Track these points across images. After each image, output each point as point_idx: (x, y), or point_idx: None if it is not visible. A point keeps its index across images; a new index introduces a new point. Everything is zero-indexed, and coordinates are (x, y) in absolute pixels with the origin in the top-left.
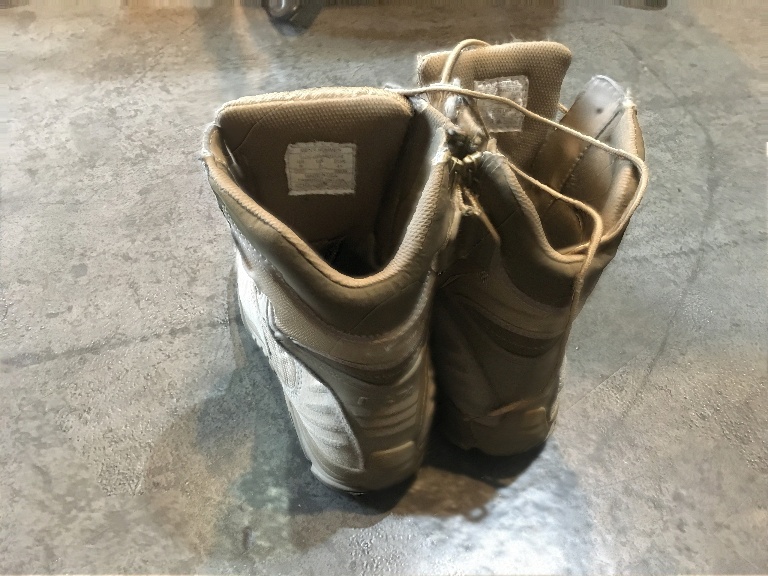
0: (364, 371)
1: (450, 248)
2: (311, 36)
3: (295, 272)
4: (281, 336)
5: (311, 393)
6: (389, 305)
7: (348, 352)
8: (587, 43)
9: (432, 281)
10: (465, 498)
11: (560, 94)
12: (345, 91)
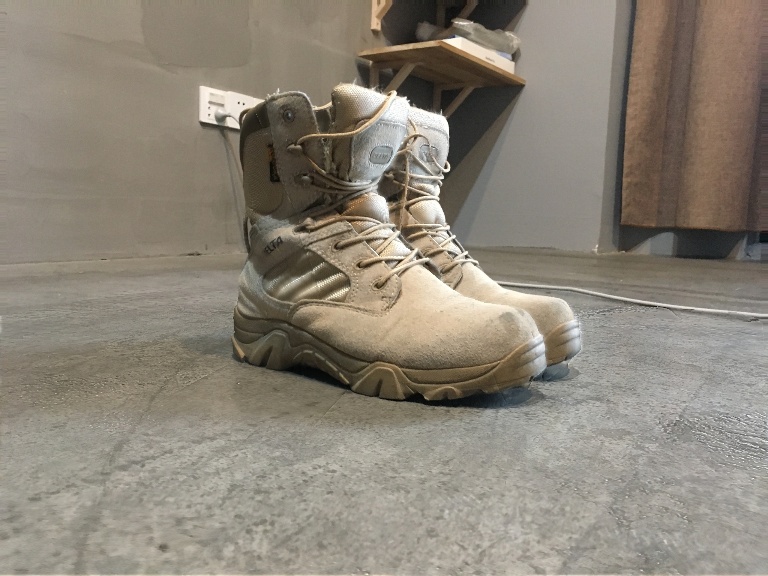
0: None
1: None
2: None
3: None
4: None
5: None
6: None
7: None
8: None
9: None
10: None
11: None
12: None
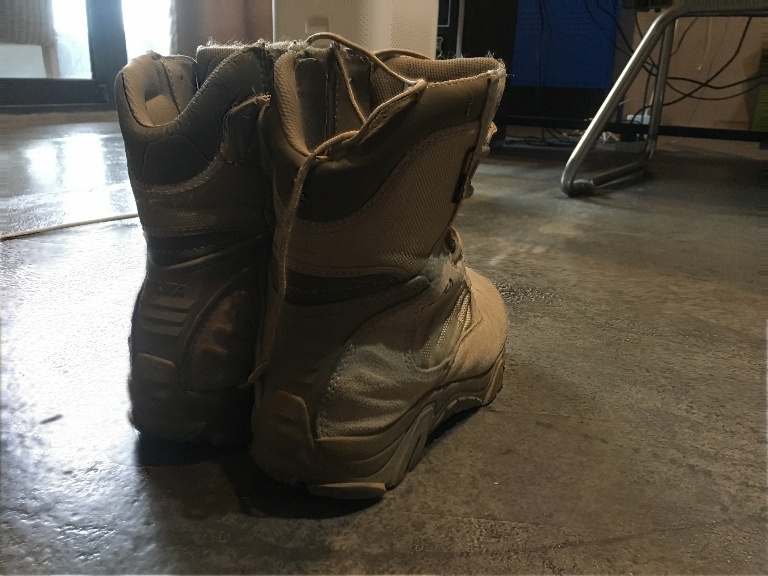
0: None
1: (234, 129)
2: (555, 254)
3: None
4: None
5: None
6: (157, 148)
7: None
8: None
9: (219, 165)
10: (207, 498)
11: None
12: None
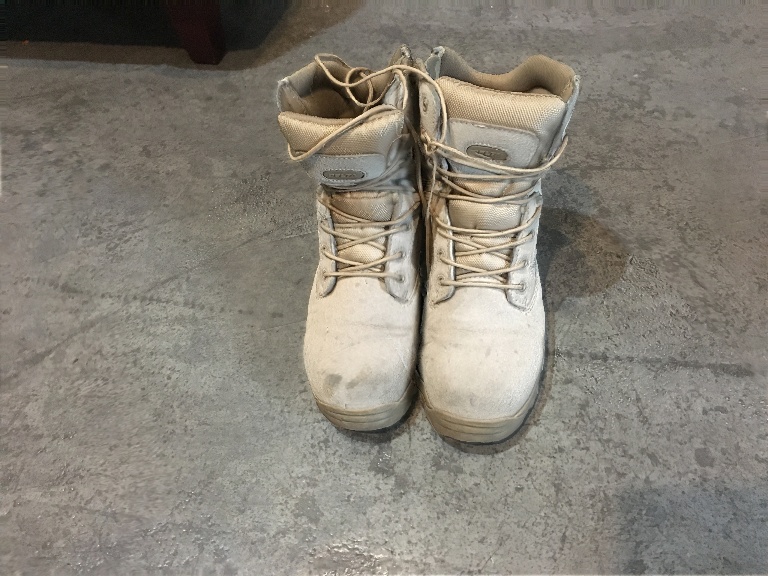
0: None
1: None
2: None
3: None
4: None
5: None
6: None
7: None
8: None
9: None
10: None
11: (10, 569)
12: (474, 90)
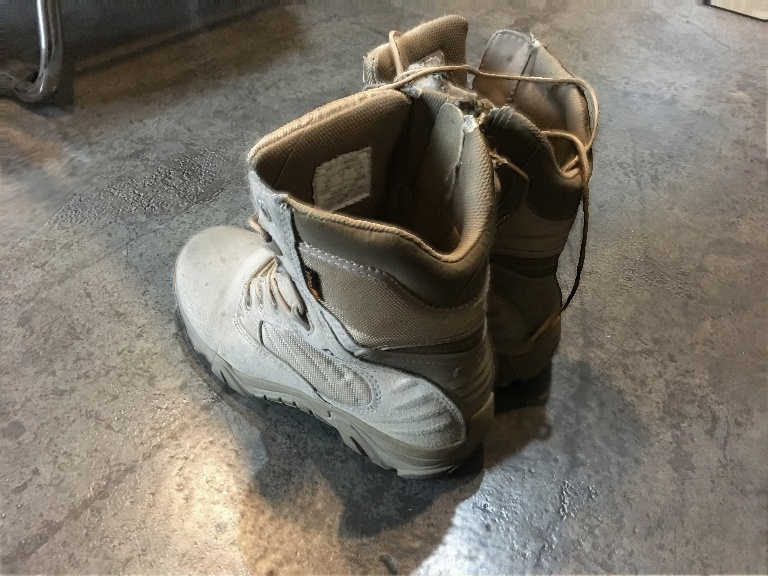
0: (460, 341)
1: None
2: (83, 109)
3: (416, 266)
4: (367, 351)
5: (398, 395)
6: (483, 265)
7: (450, 328)
8: (340, 38)
9: None
10: (527, 425)
11: (351, 86)
12: (346, 101)
